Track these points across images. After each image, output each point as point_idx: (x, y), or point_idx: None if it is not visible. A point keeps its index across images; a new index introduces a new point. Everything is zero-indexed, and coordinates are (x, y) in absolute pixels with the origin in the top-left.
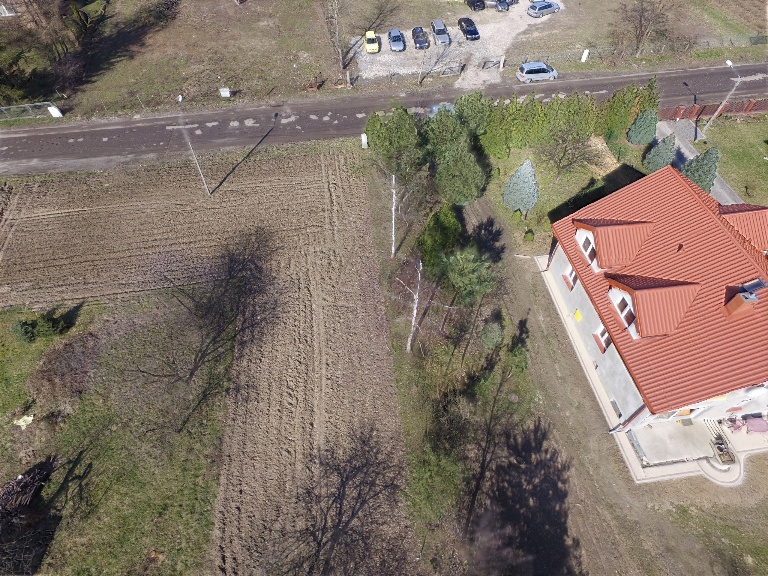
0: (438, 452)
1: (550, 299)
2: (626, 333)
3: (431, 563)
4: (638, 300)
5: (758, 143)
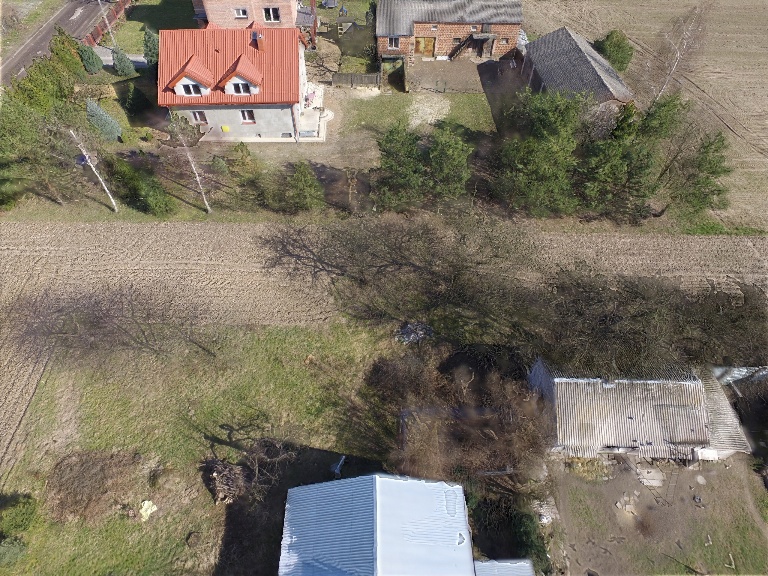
0: (285, 208)
1: (205, 142)
2: (253, 95)
3: (343, 220)
4: (241, 73)
5: (139, 33)
